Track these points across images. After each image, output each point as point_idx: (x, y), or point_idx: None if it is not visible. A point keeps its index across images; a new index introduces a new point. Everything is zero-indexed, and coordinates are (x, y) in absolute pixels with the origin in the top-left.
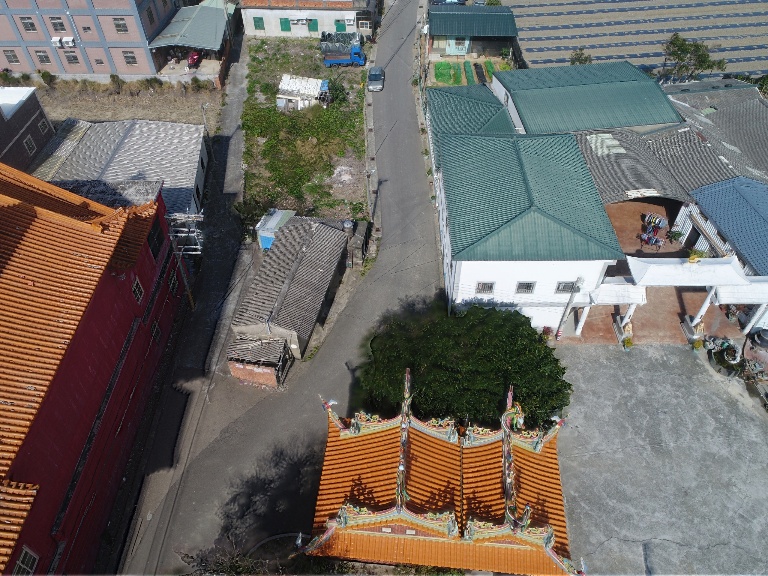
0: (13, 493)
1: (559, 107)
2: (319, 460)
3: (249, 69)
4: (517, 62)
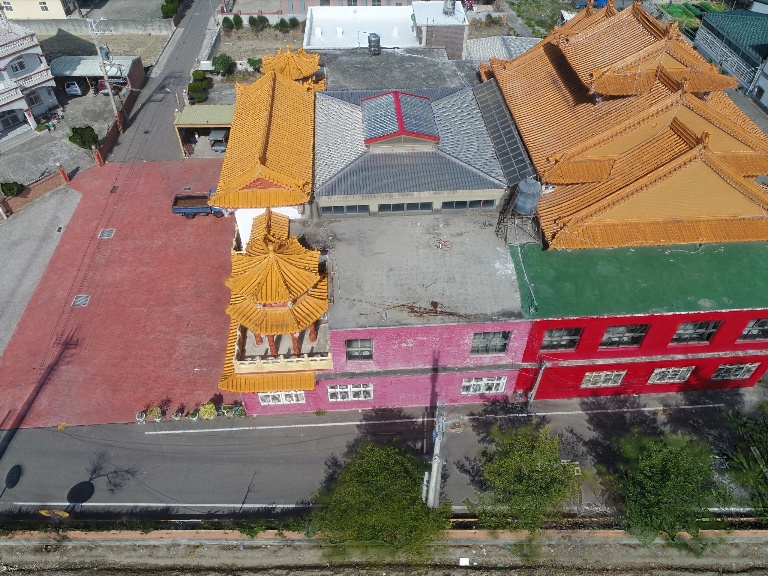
0: (763, 187)
1: None
2: None
3: (514, 11)
4: (735, 0)
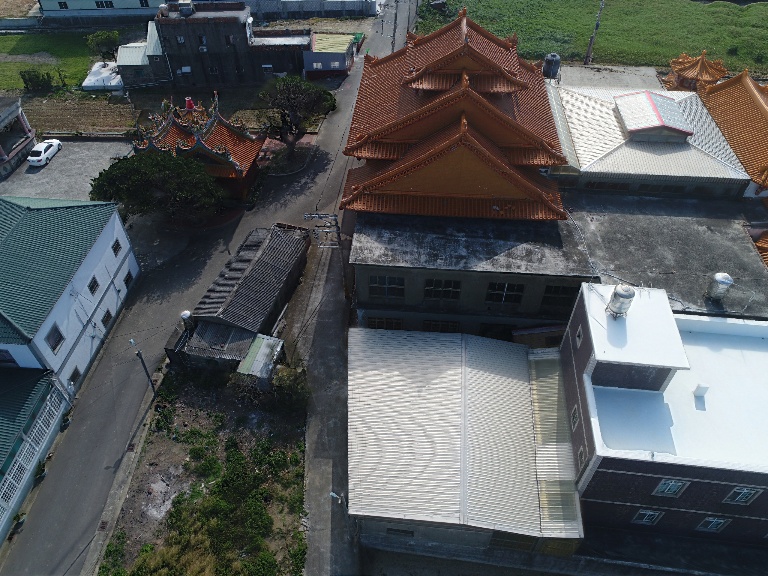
0: None
1: None
2: (260, 204)
3: None
4: None
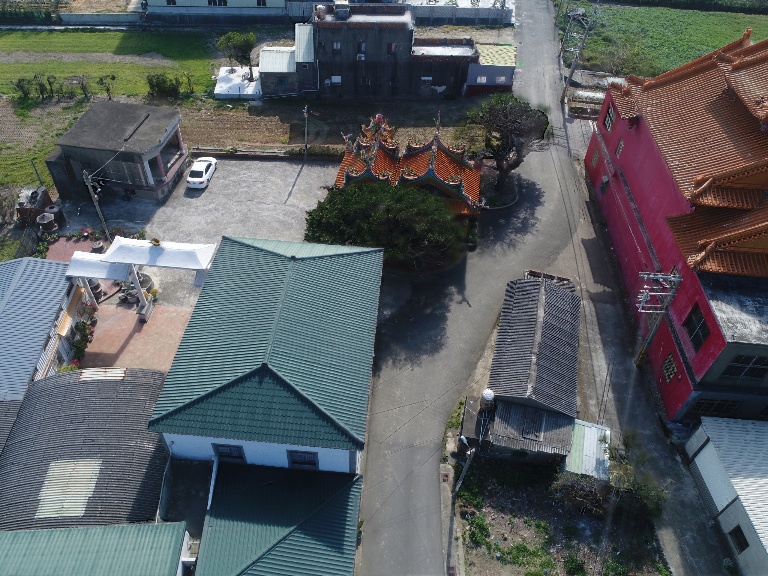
0: None
1: None
2: (482, 243)
3: None
4: None
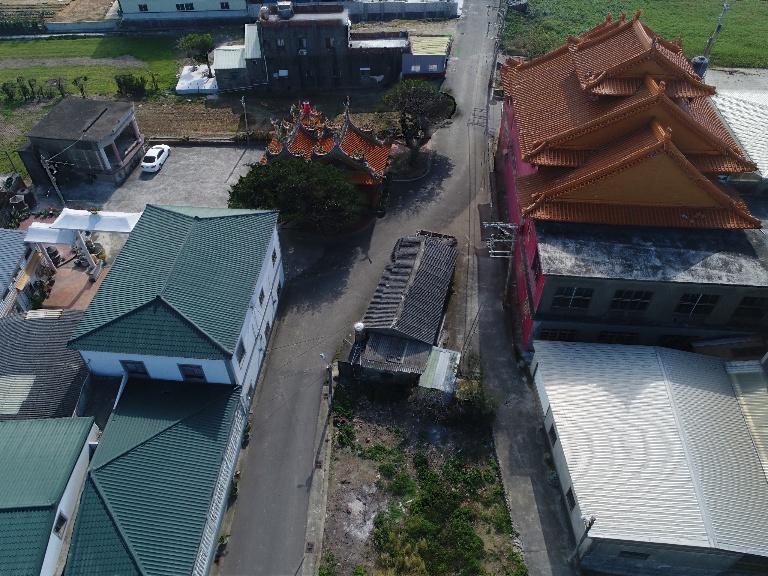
0: None
1: (7, 465)
2: (391, 211)
3: None
4: None
